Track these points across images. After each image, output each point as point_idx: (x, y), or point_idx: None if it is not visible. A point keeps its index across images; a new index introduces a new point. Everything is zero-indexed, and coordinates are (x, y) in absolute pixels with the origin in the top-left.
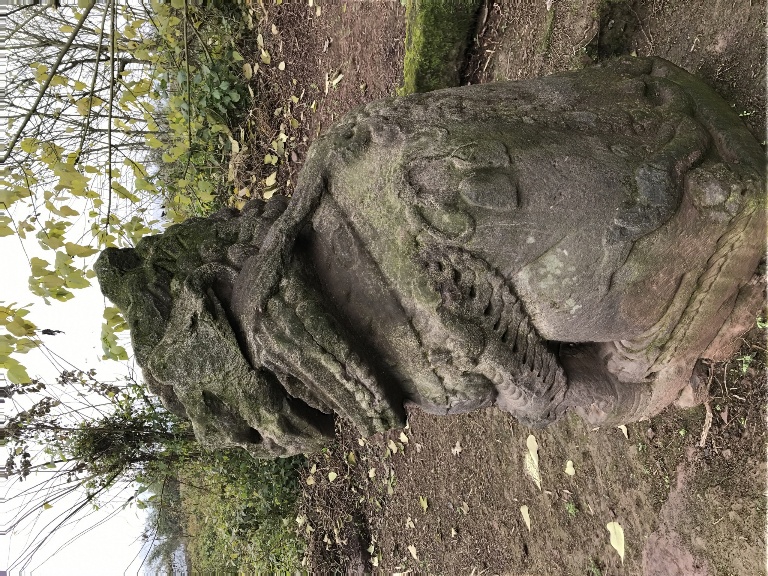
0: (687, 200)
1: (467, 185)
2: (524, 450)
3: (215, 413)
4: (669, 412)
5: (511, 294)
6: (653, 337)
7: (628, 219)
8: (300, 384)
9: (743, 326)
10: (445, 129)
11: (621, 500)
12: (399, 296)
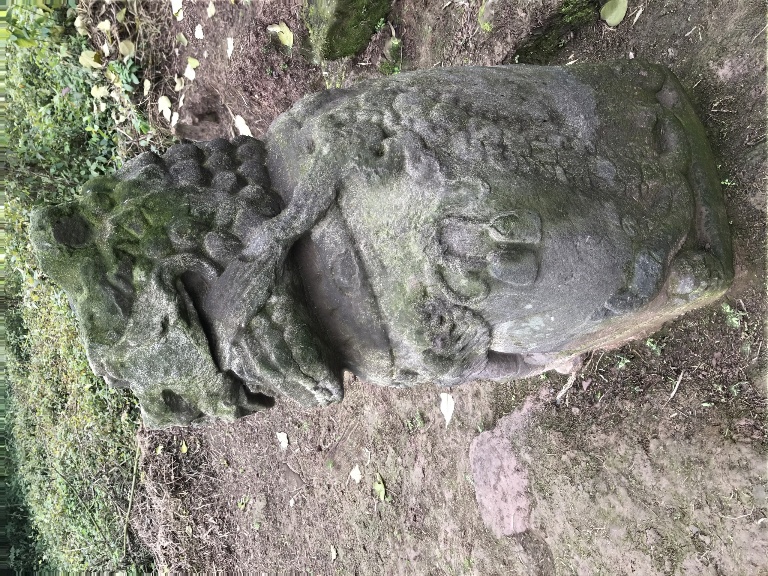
0: (664, 288)
1: (498, 261)
2: None
3: (174, 410)
4: None
5: (488, 336)
6: None
7: (617, 305)
8: None
9: (635, 337)
10: (488, 184)
11: None
12: (389, 329)
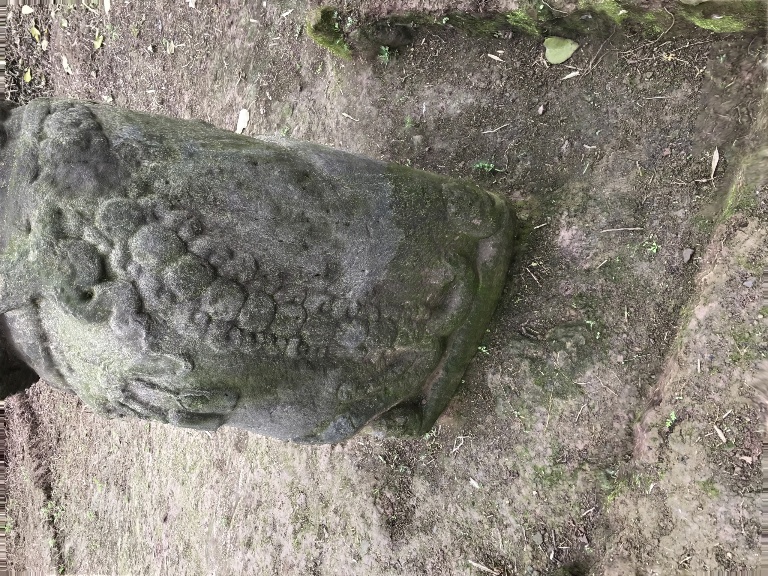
0: None
1: (176, 421)
2: (237, 108)
3: None
4: None
5: None
6: None
7: None
8: None
9: None
10: (192, 365)
11: None
12: None
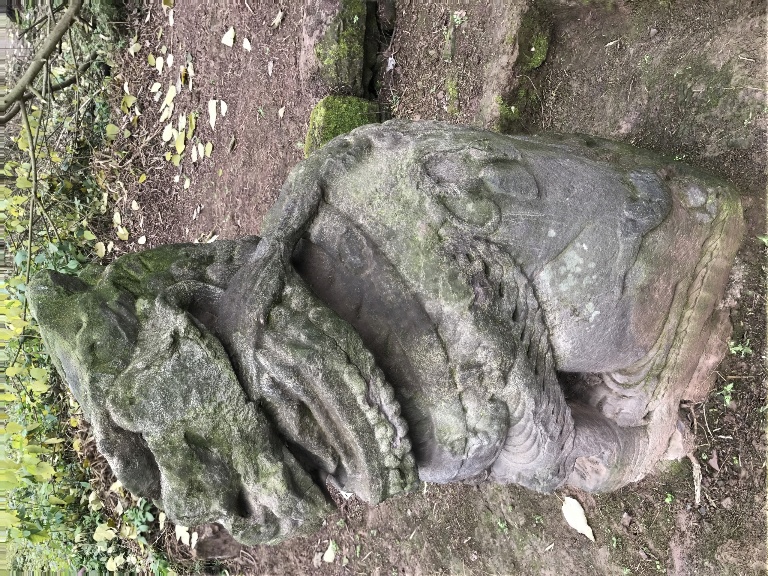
0: (675, 201)
1: (490, 171)
2: None
3: (203, 460)
4: (645, 485)
5: (534, 298)
6: (651, 364)
7: (637, 211)
8: (309, 419)
9: (716, 357)
10: (450, 132)
11: None
12: (422, 300)
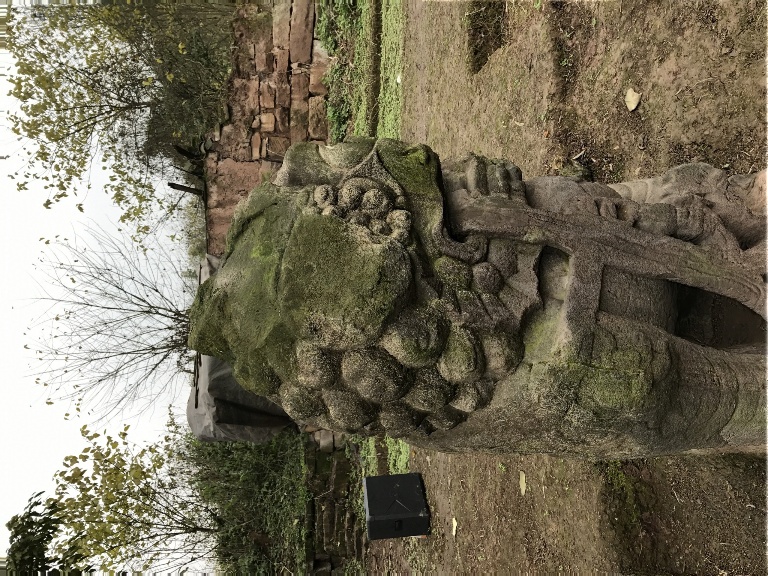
0: None
1: None
2: None
3: None
4: None
5: None
6: None
7: None
8: None
9: None
10: None
11: None
12: None
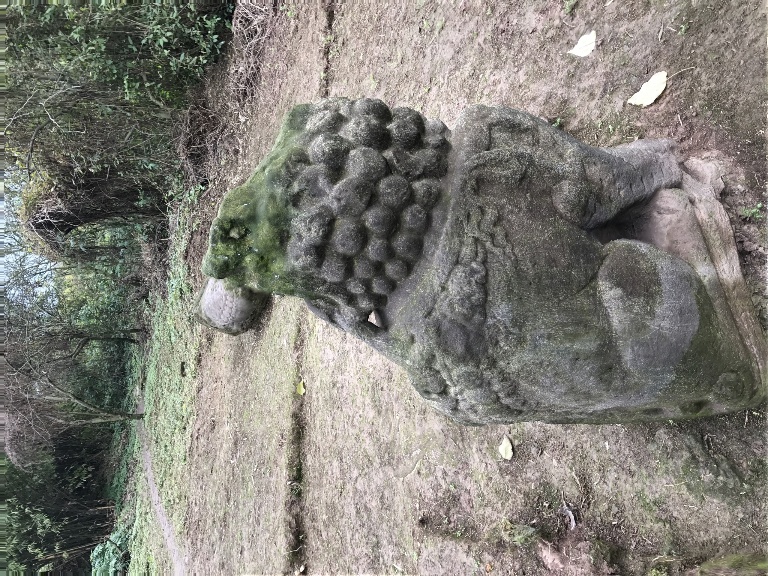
0: None
1: None
2: None
3: None
4: None
5: None
6: None
7: None
8: None
9: None
10: None
11: (601, 65)
12: None
